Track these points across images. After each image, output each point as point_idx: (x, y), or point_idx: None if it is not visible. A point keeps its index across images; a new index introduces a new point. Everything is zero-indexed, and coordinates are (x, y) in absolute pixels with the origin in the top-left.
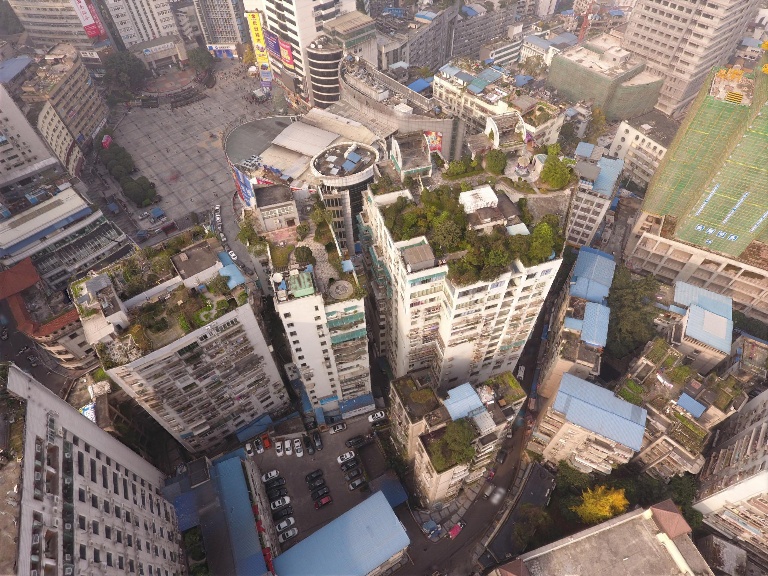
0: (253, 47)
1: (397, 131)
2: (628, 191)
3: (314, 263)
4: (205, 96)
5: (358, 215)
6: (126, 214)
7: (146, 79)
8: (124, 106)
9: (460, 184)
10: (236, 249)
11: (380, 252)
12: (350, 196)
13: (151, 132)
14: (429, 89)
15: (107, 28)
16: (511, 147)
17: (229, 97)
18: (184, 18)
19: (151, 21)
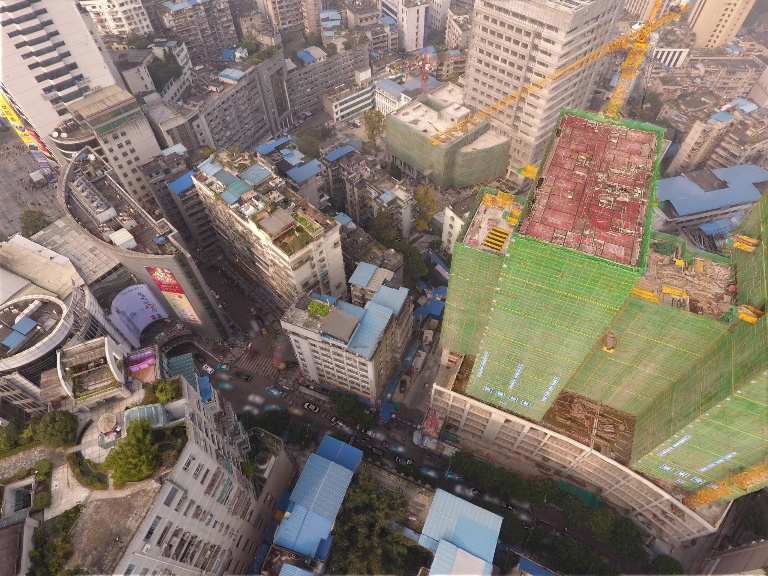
0: None
1: (119, 265)
2: None
3: None
4: None
5: None
6: None
7: None
8: None
9: None
10: None
11: None
12: (28, 376)
13: None
14: None
15: None
16: (94, 396)
17: (2, 182)
18: None
19: None
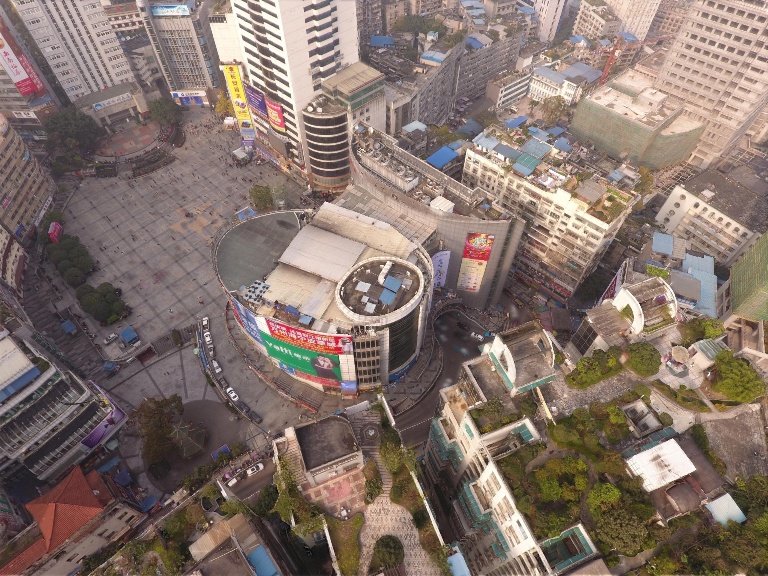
0: (231, 102)
1: (435, 231)
2: None
3: (401, 554)
4: (174, 158)
5: (435, 421)
6: (87, 337)
7: (99, 138)
8: (73, 176)
9: (606, 409)
10: (235, 383)
11: (482, 495)
12: (389, 332)
13: (110, 212)
14: (456, 158)
15: (45, 80)
16: (658, 331)
17: (204, 159)
18: (141, 61)
19: (100, 68)
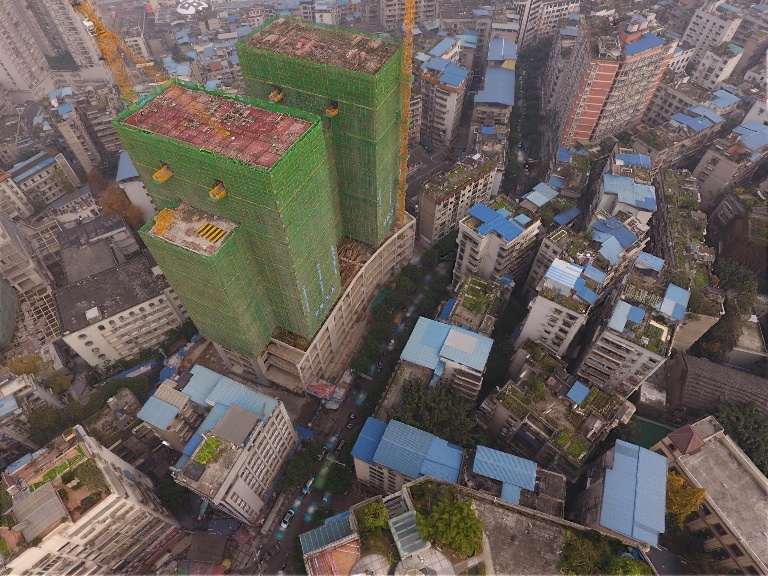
0: None
1: None
2: (174, 358)
3: None
4: None
5: None
6: None
7: None
8: None
9: None
10: None
11: None
12: None
13: None
14: None
15: None
16: None
17: None
18: None
19: None
